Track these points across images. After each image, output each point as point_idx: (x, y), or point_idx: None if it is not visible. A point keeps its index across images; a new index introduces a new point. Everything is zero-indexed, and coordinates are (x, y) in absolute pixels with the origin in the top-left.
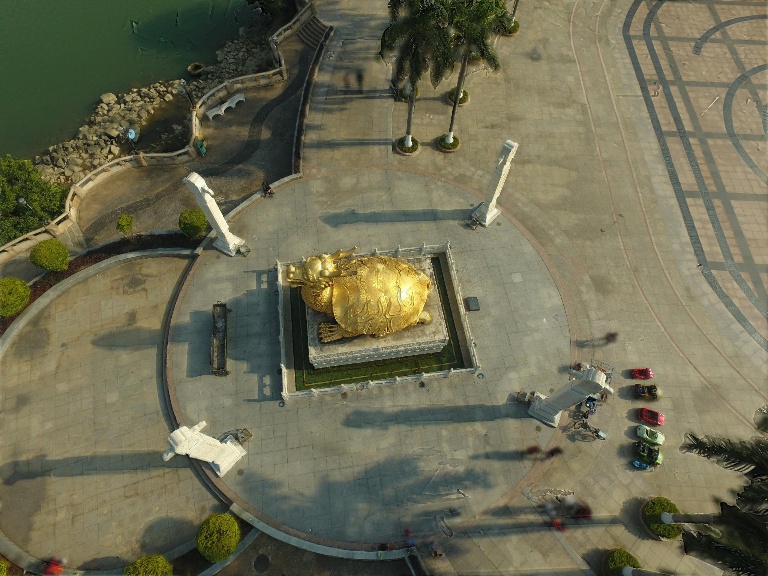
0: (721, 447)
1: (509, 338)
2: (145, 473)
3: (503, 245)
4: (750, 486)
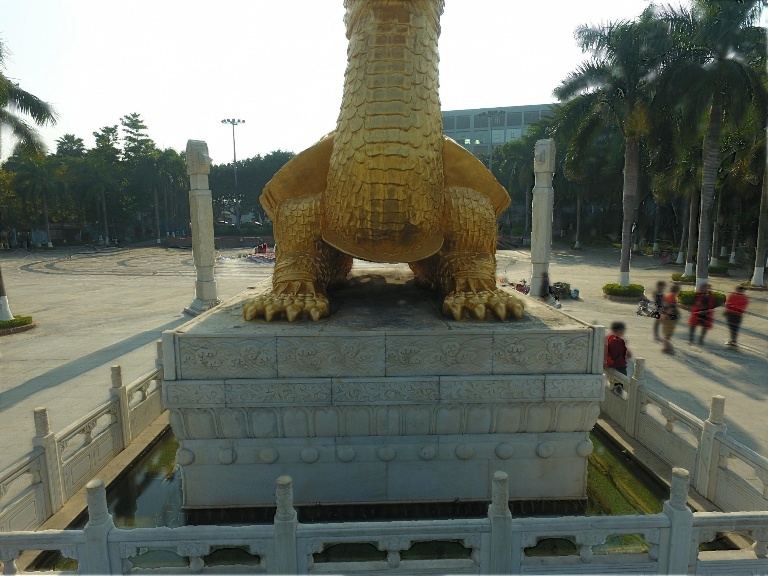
0: (607, 96)
1: None
2: None
3: None
4: (651, 44)
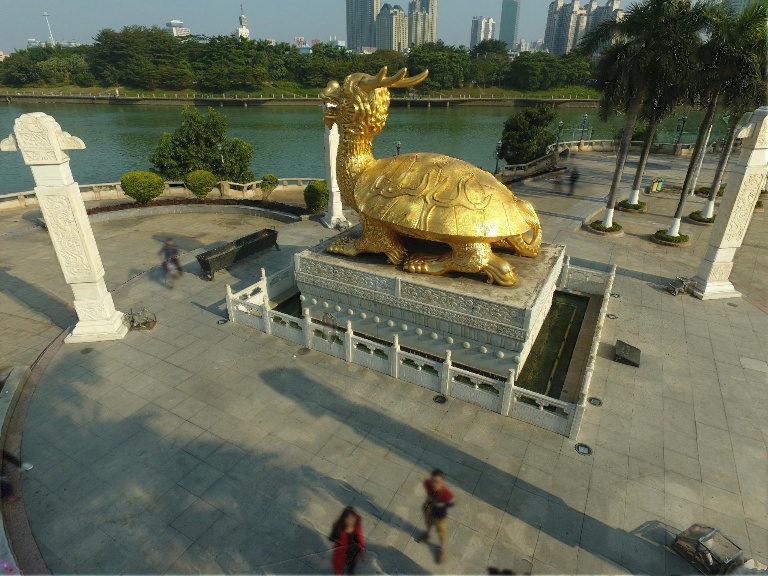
0: None
1: (697, 429)
2: (31, 313)
3: (733, 324)
4: None
